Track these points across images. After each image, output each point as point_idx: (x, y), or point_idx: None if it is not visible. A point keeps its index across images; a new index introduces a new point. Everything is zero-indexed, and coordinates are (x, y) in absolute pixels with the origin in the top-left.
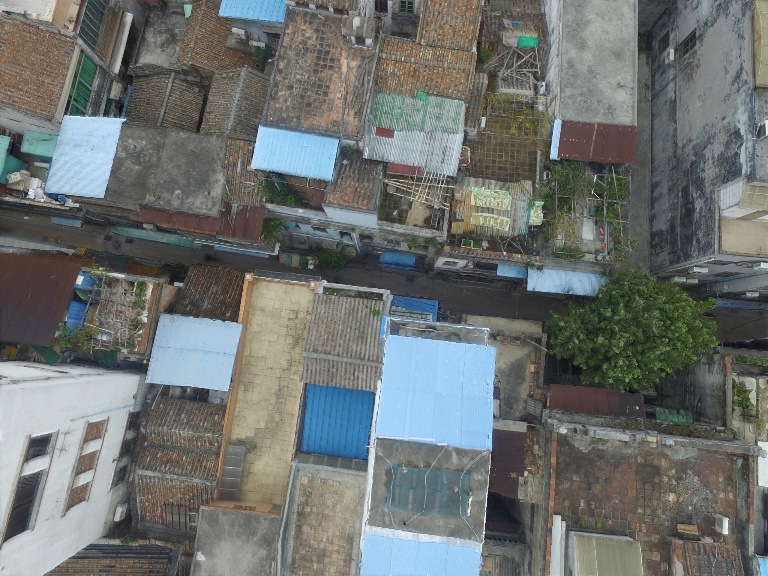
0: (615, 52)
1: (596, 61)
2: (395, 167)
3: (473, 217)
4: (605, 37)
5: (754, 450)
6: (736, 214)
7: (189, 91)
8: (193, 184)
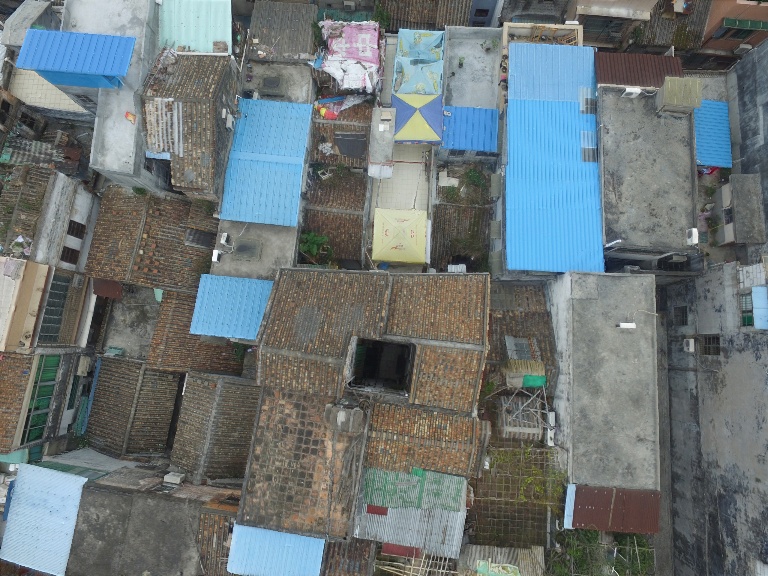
0: (633, 397)
1: (612, 409)
2: (390, 548)
3: None
4: (621, 379)
5: None
6: None
7: (162, 379)
8: (164, 562)
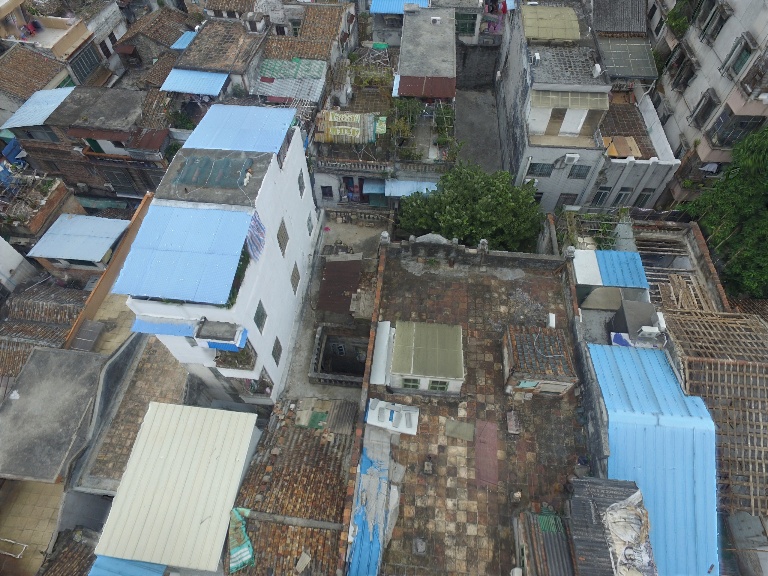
0: (440, 46)
1: (426, 50)
2: (272, 98)
3: (331, 129)
4: (433, 41)
5: (566, 251)
6: (540, 126)
7: None
8: (116, 114)
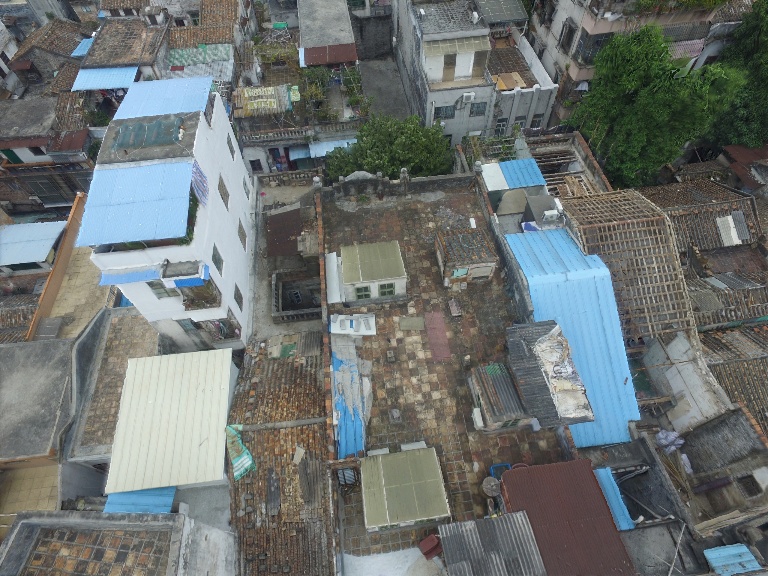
0: (335, 18)
1: (324, 23)
2: None
3: (249, 104)
4: (328, 14)
5: (474, 167)
6: (437, 73)
7: None
8: (29, 122)
